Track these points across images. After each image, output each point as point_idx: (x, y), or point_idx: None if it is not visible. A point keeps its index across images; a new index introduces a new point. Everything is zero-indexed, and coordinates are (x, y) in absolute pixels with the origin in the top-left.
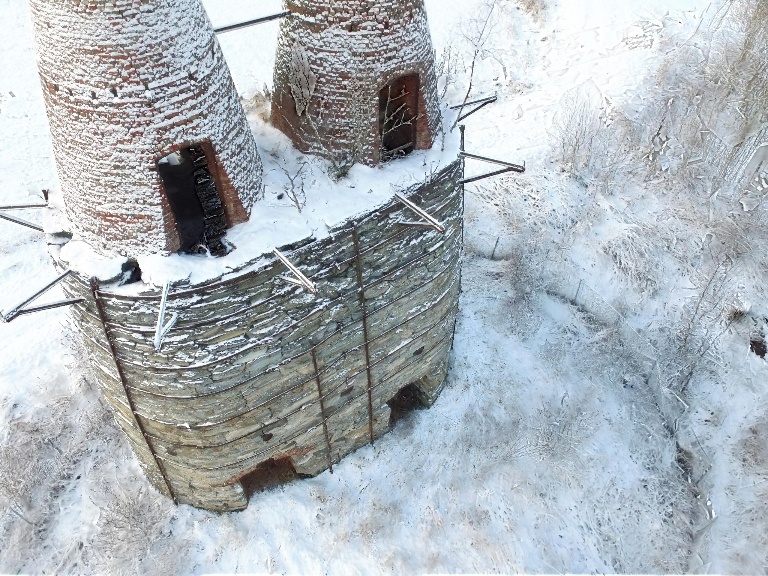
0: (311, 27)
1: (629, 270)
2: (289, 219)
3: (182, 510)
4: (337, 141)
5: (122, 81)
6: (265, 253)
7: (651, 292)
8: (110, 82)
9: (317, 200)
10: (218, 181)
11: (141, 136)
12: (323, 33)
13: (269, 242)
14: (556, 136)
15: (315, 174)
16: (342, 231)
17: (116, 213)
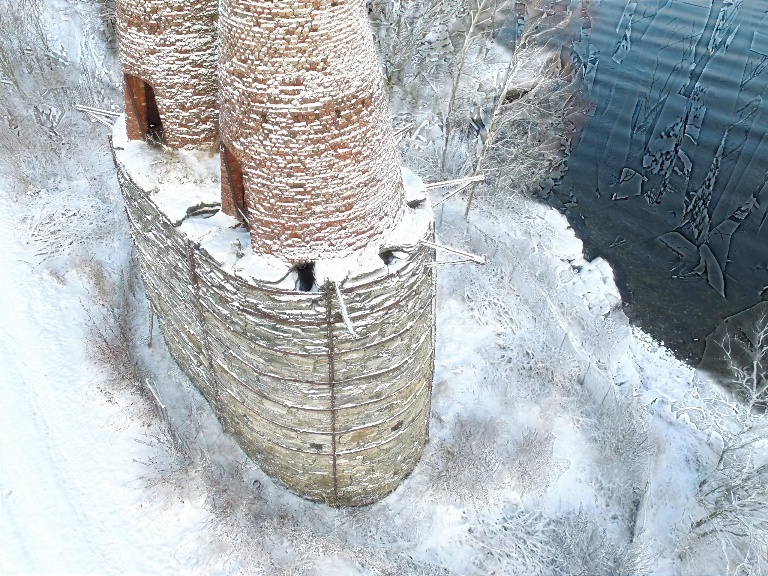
0: None
1: None
2: None
3: (433, 434)
4: None
5: None
6: None
7: None
8: None
9: None
10: None
11: None
12: None
13: None
14: (14, 170)
15: None
16: None
17: None
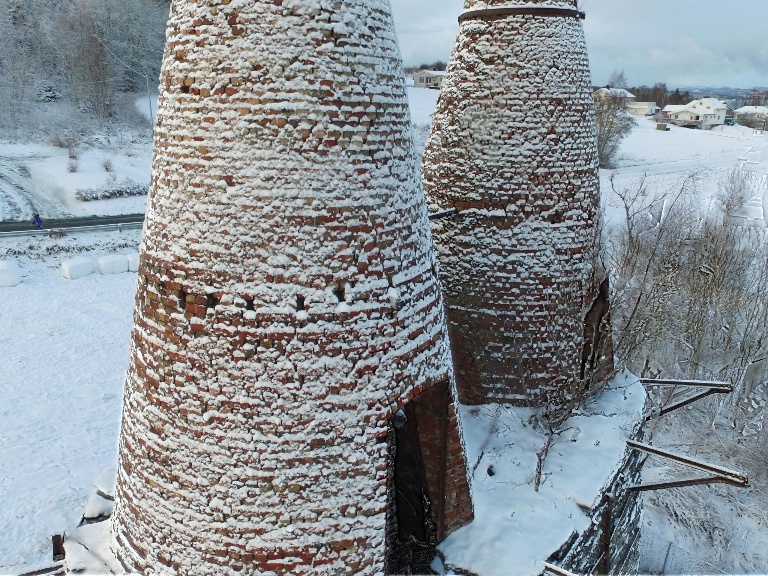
0: (498, 223)
1: (689, 521)
2: (530, 505)
3: None
4: (533, 376)
5: (356, 272)
6: (535, 575)
7: (724, 543)
8: (336, 275)
9: (548, 467)
10: (441, 453)
11: (372, 374)
12: (517, 228)
13: (530, 553)
14: None
15: (515, 429)
16: (598, 512)
17: (294, 547)
